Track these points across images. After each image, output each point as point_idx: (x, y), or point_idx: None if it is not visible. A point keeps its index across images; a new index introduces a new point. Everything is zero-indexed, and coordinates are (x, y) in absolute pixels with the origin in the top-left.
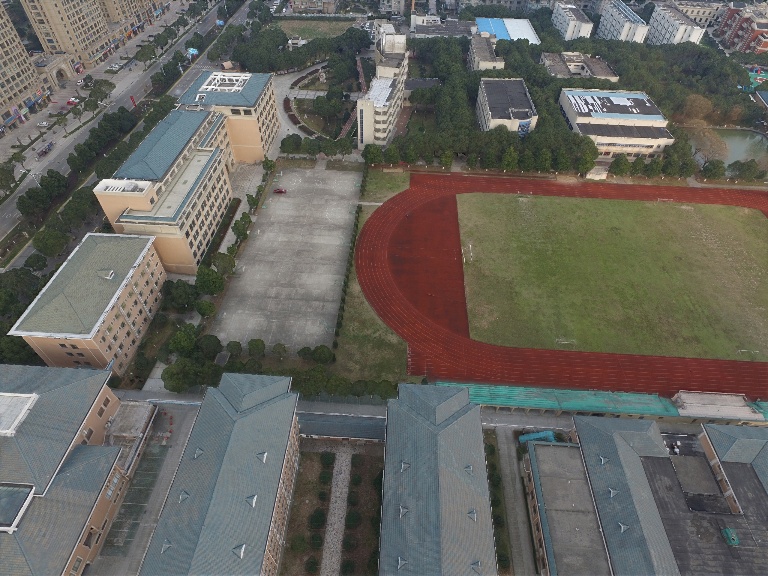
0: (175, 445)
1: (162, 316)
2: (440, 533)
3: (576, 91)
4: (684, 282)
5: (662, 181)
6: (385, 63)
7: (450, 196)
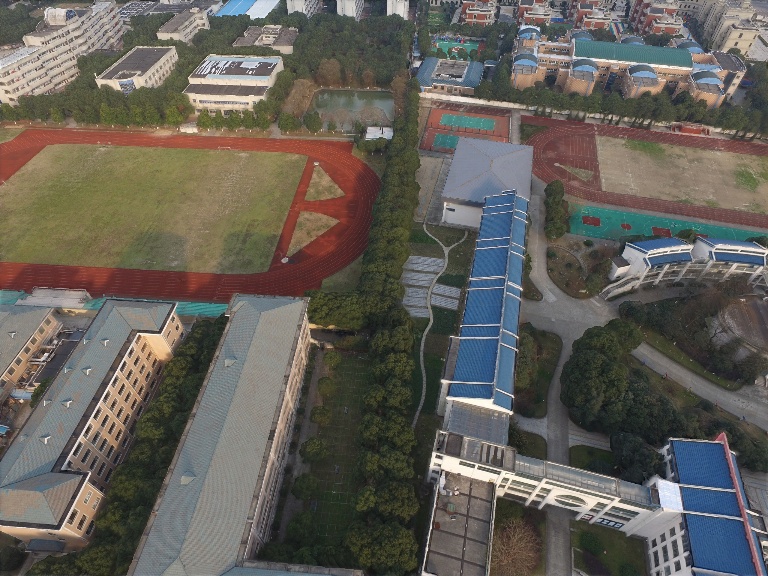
0: None
1: None
2: None
3: (221, 57)
4: (163, 212)
5: (248, 134)
6: (39, 33)
7: (40, 147)
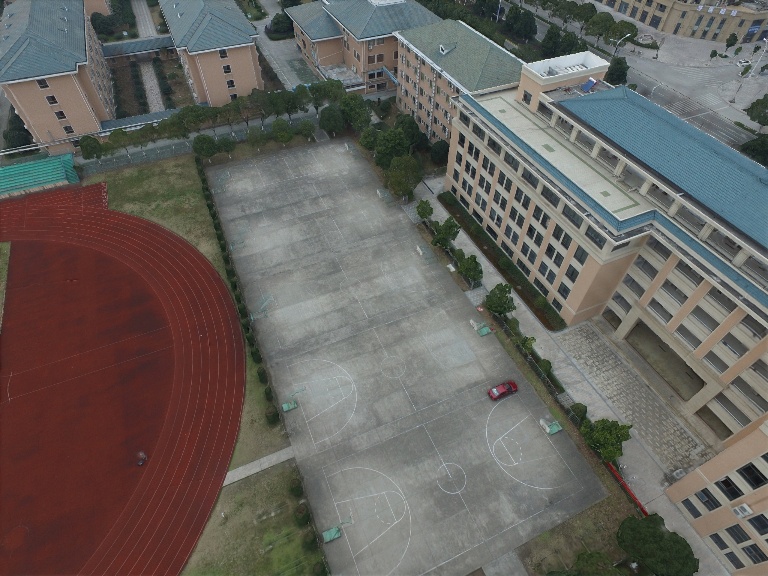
0: None
1: None
2: (31, 4)
3: None
4: None
5: None
6: None
7: None
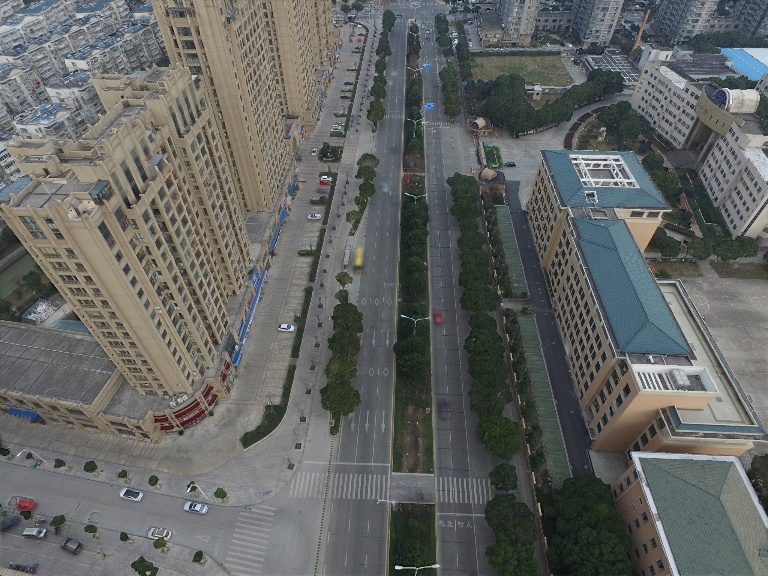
0: None
1: None
2: None
3: None
4: None
5: None
6: (744, 128)
7: None
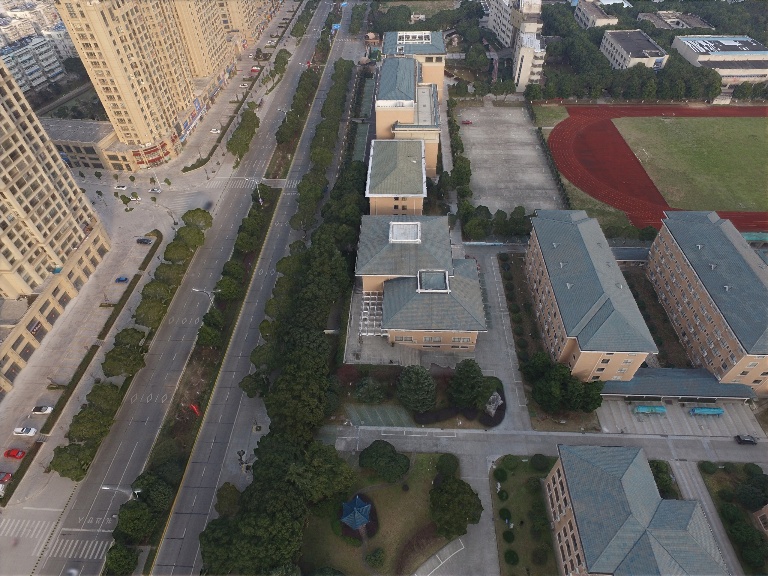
0: (487, 273)
1: (434, 199)
2: (751, 268)
3: (687, 38)
4: None
5: None
6: (527, 21)
7: (606, 120)
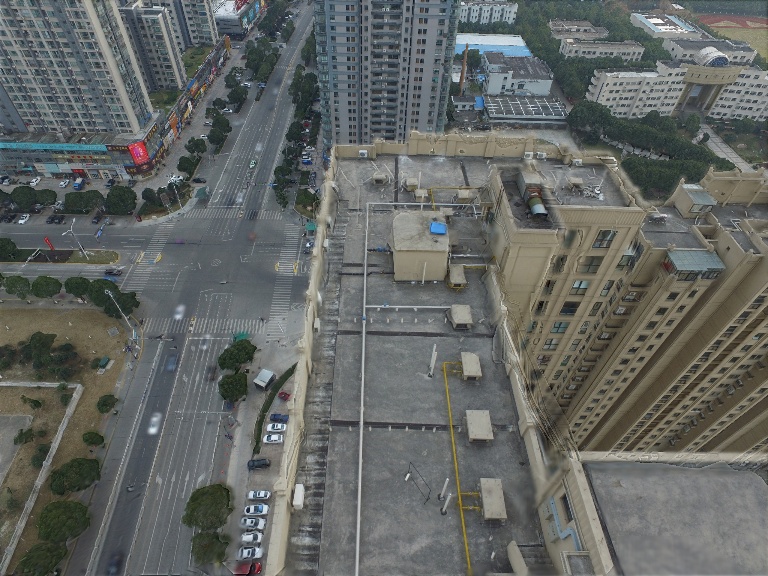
0: None
1: None
2: None
3: None
4: None
5: None
6: None
7: None
